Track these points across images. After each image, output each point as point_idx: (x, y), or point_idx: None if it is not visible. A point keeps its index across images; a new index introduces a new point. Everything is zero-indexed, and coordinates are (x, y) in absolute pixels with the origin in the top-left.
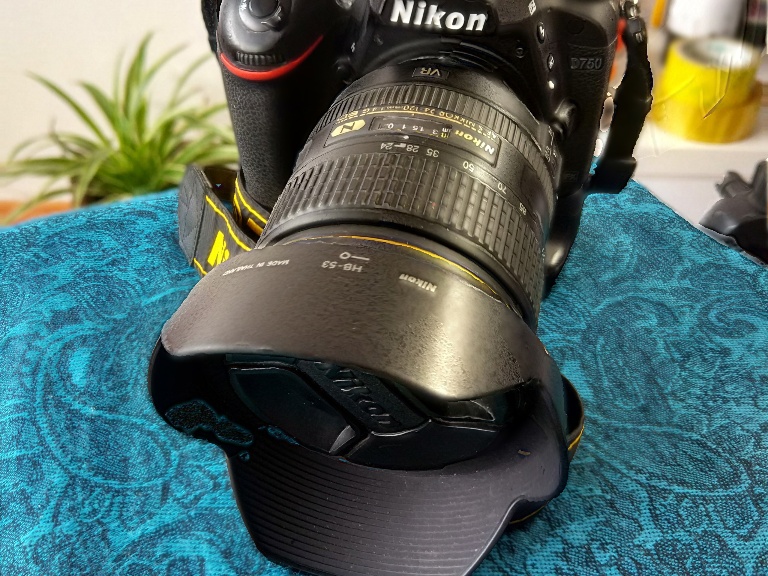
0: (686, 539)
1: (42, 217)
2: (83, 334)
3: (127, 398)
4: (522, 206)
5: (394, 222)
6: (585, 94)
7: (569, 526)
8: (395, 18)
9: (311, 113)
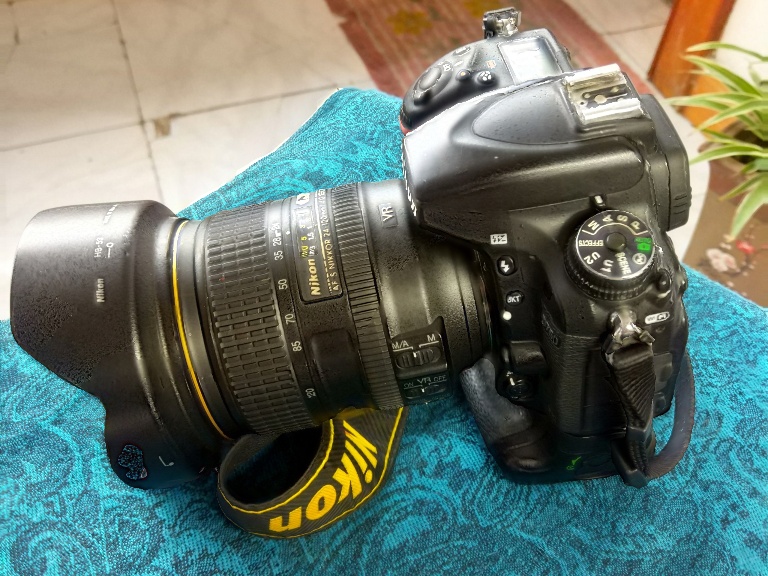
0: None
1: None
2: None
3: None
4: (298, 344)
5: (195, 264)
6: None
7: (235, 555)
8: None
9: None
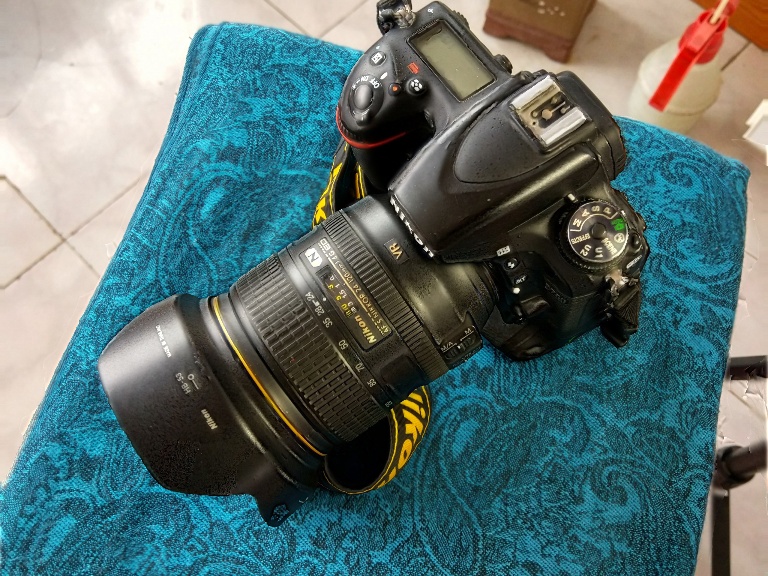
0: (396, 575)
1: (288, 36)
2: (231, 176)
3: (218, 245)
4: (373, 381)
5: (262, 356)
6: (555, 305)
7: (352, 514)
8: (392, 203)
9: (393, 162)
